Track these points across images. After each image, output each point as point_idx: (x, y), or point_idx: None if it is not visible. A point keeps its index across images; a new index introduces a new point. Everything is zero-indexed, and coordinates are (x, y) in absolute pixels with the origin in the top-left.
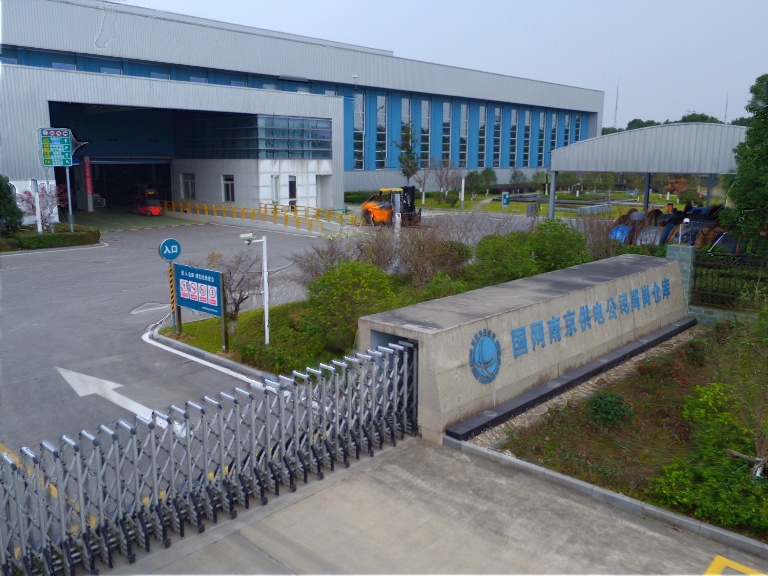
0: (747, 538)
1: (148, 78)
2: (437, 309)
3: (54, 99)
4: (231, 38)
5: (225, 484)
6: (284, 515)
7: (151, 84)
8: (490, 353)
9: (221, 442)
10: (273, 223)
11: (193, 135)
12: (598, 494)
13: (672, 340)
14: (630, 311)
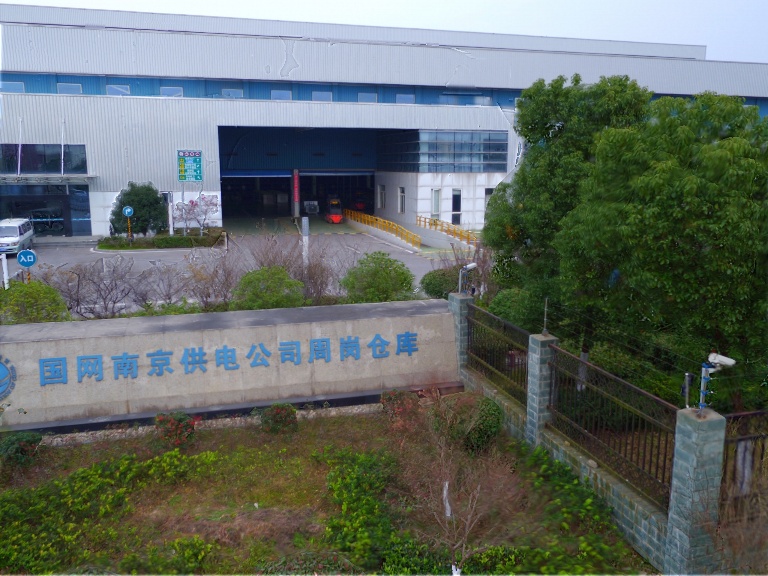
0: None
1: (307, 101)
2: None
3: (223, 124)
4: (438, 54)
5: None
6: None
7: (310, 106)
8: None
9: None
10: (395, 236)
11: (385, 149)
12: None
13: None
14: (306, 362)
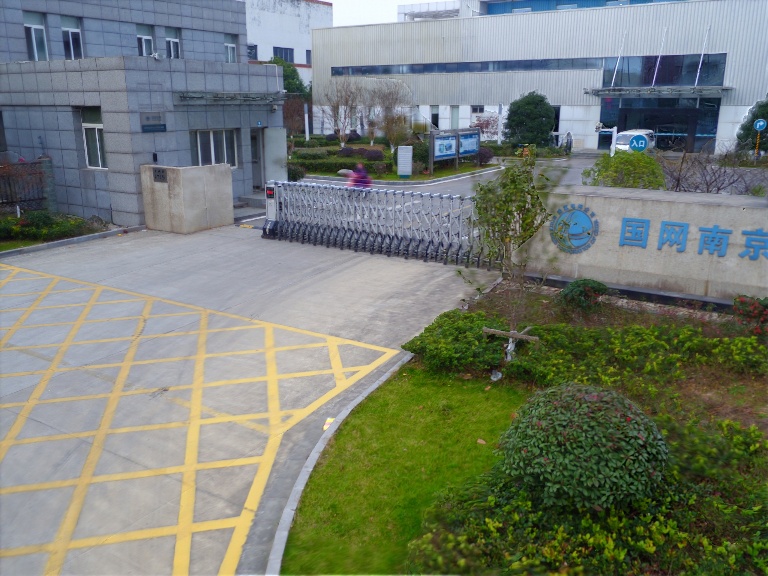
0: None
1: None
2: (600, 189)
3: None
4: None
5: (376, 236)
6: (381, 260)
7: None
8: (580, 228)
9: None
10: None
11: None
12: None
13: None
14: None
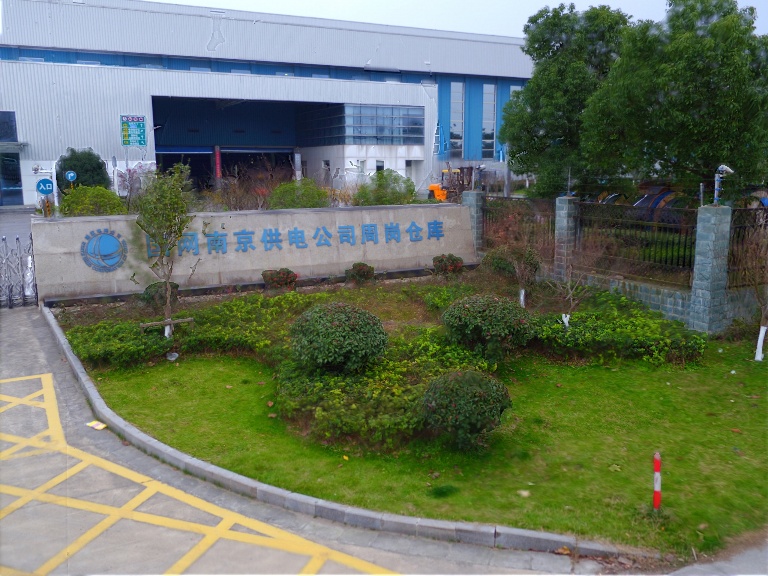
0: (79, 364)
1: (238, 74)
2: None
3: (156, 94)
4: (351, 37)
5: None
6: None
7: (242, 79)
8: (111, 249)
9: None
10: None
11: (305, 126)
12: (57, 338)
13: (422, 277)
14: (359, 243)
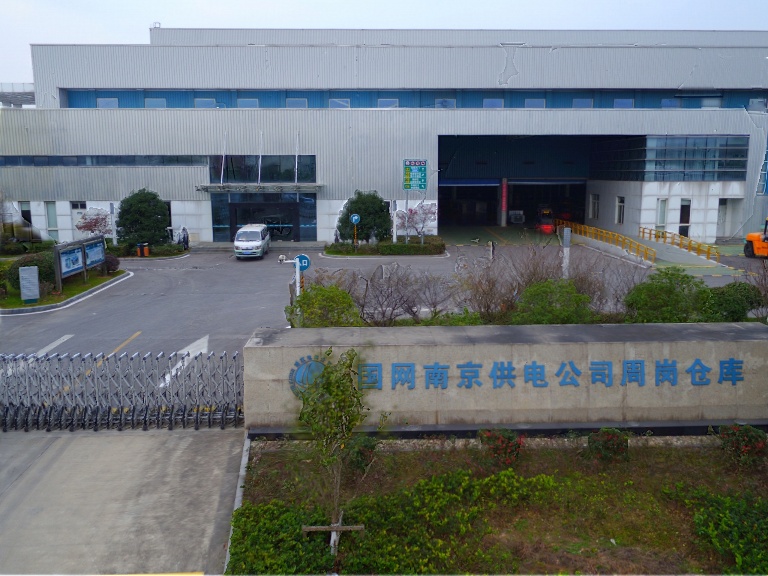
0: None
1: (528, 109)
2: (322, 333)
3: (443, 133)
4: (663, 55)
5: (74, 409)
6: (89, 439)
7: (531, 114)
8: None
9: (72, 382)
10: (621, 248)
11: (601, 157)
12: None
13: (704, 437)
14: (617, 384)
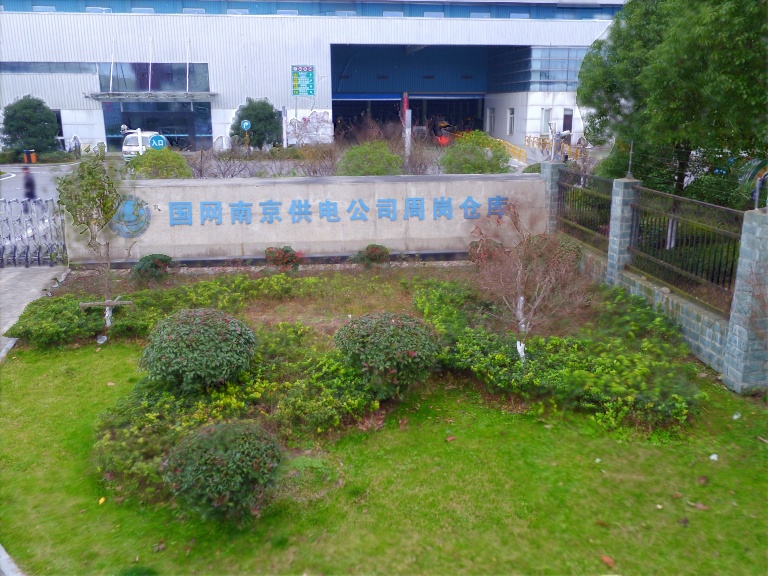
0: (16, 339)
1: (418, 18)
2: None
3: (335, 42)
4: None
5: None
6: None
7: (421, 23)
8: None
9: None
10: None
11: (496, 70)
12: None
13: (471, 261)
14: (401, 219)
